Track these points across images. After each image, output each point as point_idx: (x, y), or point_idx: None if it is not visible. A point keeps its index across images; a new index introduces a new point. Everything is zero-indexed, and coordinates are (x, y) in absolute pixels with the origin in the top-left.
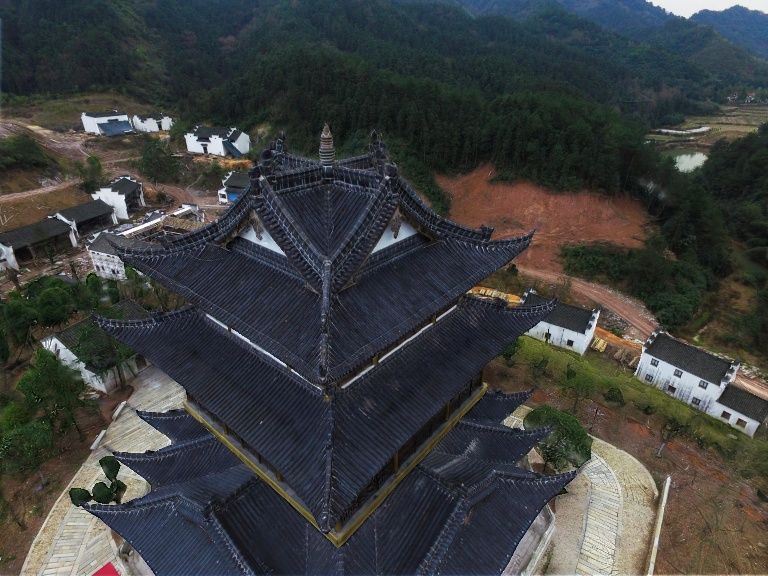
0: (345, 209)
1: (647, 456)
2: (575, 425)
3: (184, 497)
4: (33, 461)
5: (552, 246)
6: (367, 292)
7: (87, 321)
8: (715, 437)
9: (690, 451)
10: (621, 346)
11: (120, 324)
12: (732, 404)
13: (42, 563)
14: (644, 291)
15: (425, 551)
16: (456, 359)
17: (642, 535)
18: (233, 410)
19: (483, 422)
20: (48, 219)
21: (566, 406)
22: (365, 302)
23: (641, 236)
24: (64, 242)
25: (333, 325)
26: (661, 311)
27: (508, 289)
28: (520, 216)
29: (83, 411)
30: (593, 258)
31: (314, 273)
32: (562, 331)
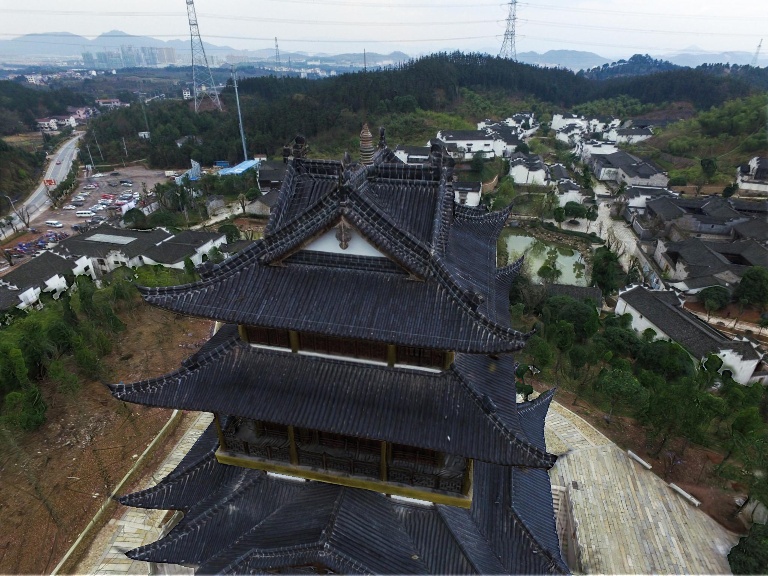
0: None
1: None
2: None
3: None
4: None
5: None
6: None
7: None
8: None
9: None
10: None
11: None
12: None
13: None
14: None
15: None
16: None
17: None
18: None
19: (225, 547)
20: None
21: None
22: None
23: None
24: None
25: None
26: None
27: None
28: None
29: (714, 483)
30: None
31: None
32: None
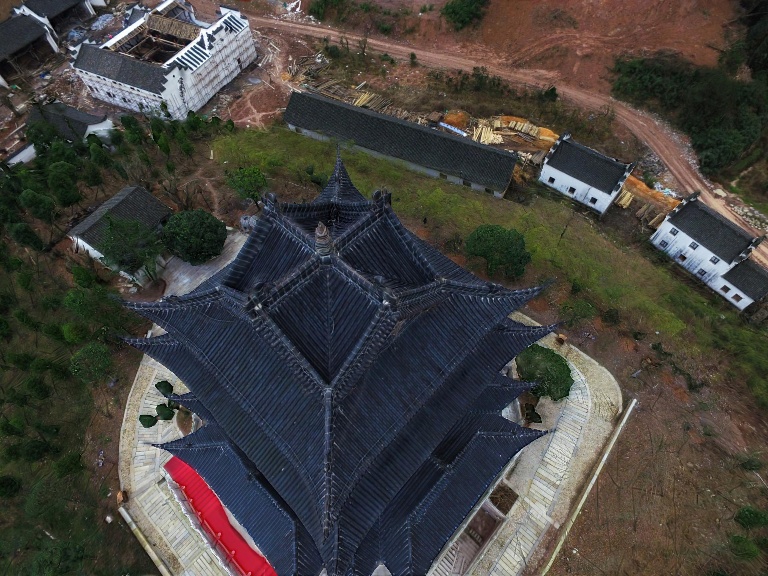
0: (345, 306)
1: (623, 375)
2: (561, 369)
3: (230, 449)
4: (101, 373)
5: (605, 57)
6: (367, 390)
7: (105, 218)
8: (699, 335)
9: (665, 369)
10: (647, 200)
11: (147, 342)
12: (735, 281)
13: (132, 447)
14: (696, 125)
15: (415, 501)
16: (450, 396)
17: (596, 447)
18: (259, 453)
19: None
20: (16, 18)
21: (564, 318)
22: (365, 403)
23: (719, 42)
24: (44, 47)
25: (335, 445)
26: (707, 152)
27: (542, 119)
28: (576, 8)
29: None
30: (650, 78)
31: (317, 387)
32: (587, 190)
